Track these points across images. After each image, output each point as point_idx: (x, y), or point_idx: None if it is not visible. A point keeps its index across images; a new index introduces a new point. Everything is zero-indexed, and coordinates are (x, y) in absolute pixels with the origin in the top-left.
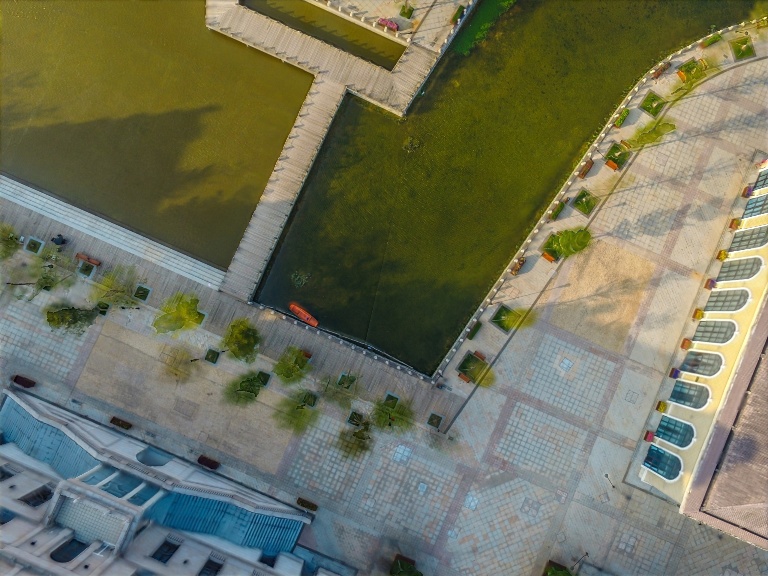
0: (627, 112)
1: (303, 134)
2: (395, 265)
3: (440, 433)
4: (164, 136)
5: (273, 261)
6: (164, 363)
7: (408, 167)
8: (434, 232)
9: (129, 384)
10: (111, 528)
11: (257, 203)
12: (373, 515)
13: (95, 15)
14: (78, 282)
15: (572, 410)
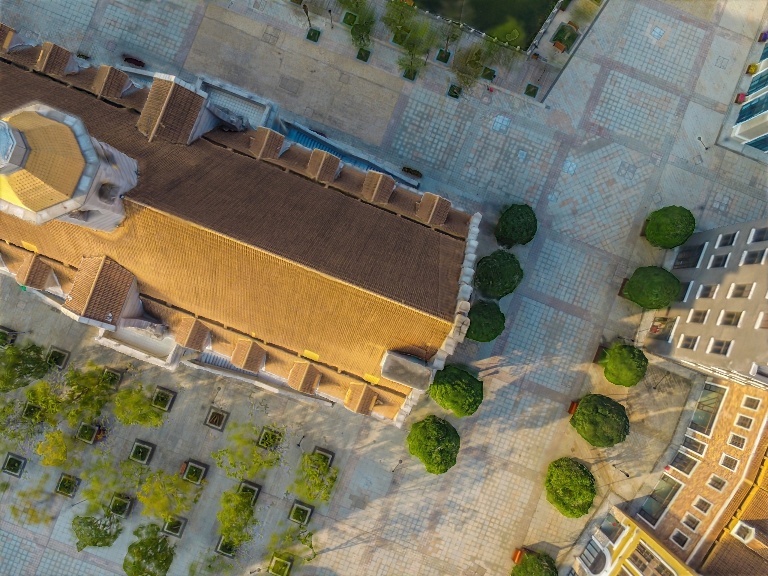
0: None
1: None
2: None
3: (537, 102)
4: None
5: None
6: (267, 43)
7: None
8: None
9: (235, 64)
10: None
11: None
12: (475, 182)
13: None
14: None
15: (664, 77)
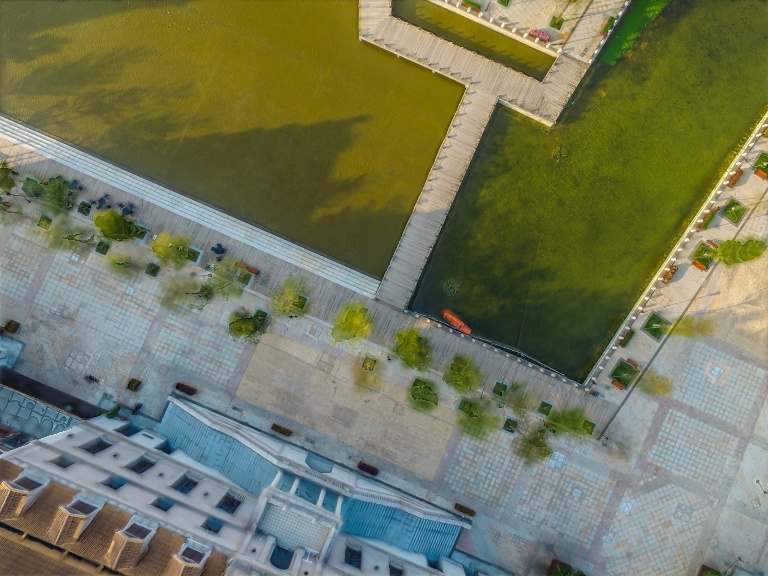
0: None
1: (456, 144)
2: (544, 273)
3: (594, 439)
4: (317, 146)
5: (425, 270)
6: (322, 371)
7: (556, 176)
8: (583, 241)
9: (288, 391)
10: (312, 535)
11: (409, 212)
12: (529, 520)
13: (247, 26)
14: (236, 291)
15: (723, 417)
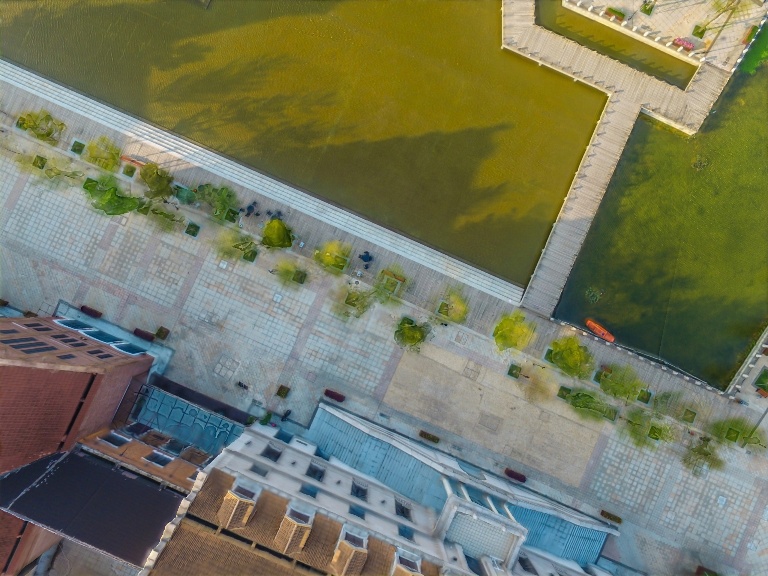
0: None
1: (600, 152)
2: (685, 281)
3: (738, 447)
4: (459, 154)
5: None
6: (468, 378)
7: (696, 185)
8: (723, 249)
9: (435, 398)
10: (496, 543)
11: (552, 220)
12: (674, 527)
13: (390, 34)
14: (383, 298)
15: None
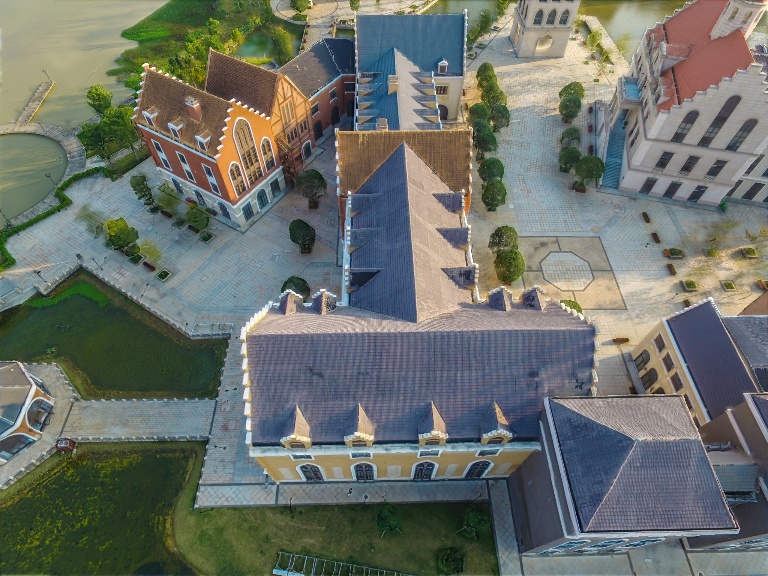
0: (425, 2)
1: None
2: None
3: None
4: (598, 1)
5: None
6: None
7: None
8: None
9: None
10: None
11: None
12: None
13: None
14: None
15: None
